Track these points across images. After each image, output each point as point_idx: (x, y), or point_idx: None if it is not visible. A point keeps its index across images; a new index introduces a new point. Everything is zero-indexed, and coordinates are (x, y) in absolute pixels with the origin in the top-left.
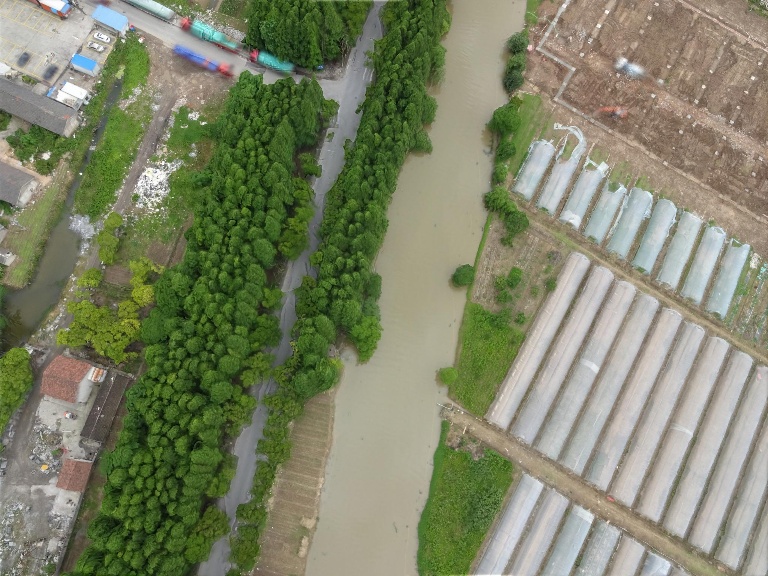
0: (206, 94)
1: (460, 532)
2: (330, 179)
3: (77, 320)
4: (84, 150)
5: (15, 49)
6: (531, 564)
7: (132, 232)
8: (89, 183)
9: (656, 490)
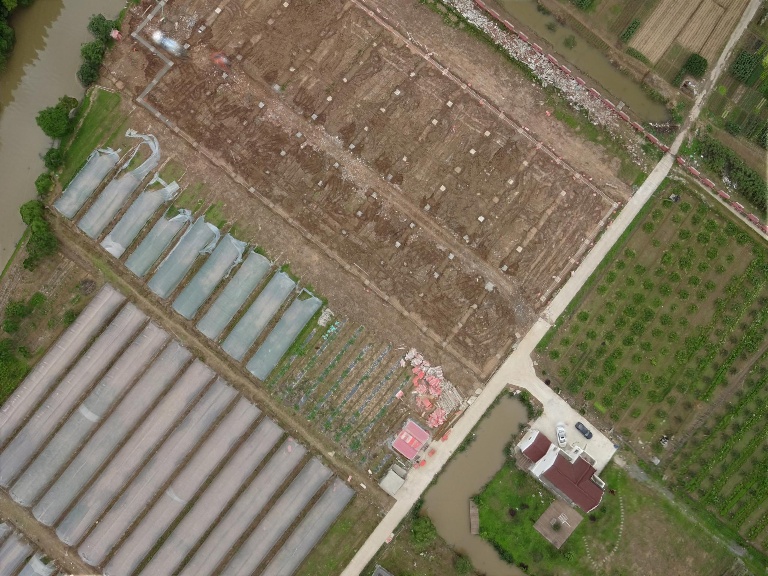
0: None
1: None
2: None
3: None
4: None
5: None
6: None
7: None
8: None
9: (133, 552)
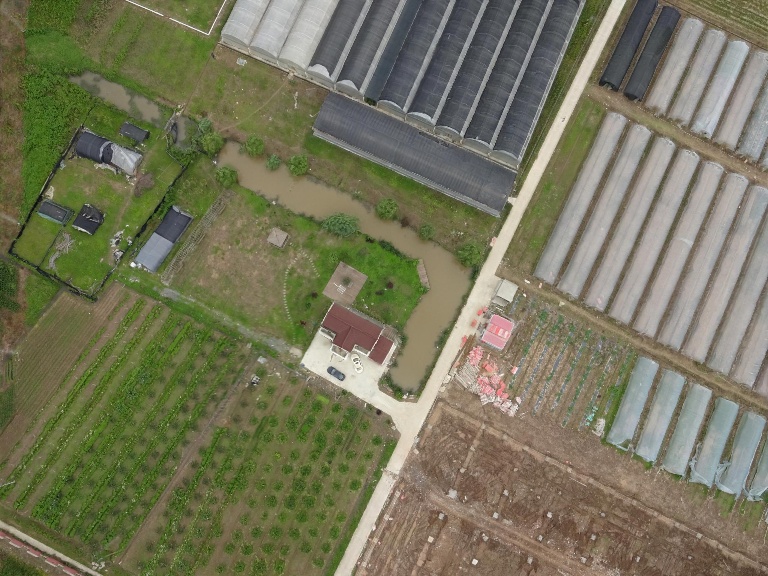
0: None
1: None
2: None
3: None
4: None
5: None
6: None
7: None
8: None
9: (703, 189)
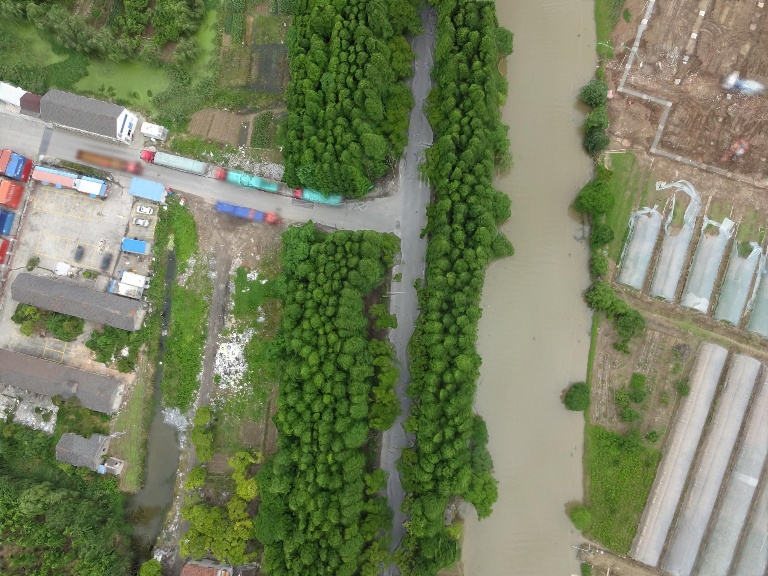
0: (259, 247)
1: None
2: (407, 316)
3: (193, 528)
4: (157, 338)
5: (69, 244)
6: None
7: (222, 416)
8: (170, 374)
9: None
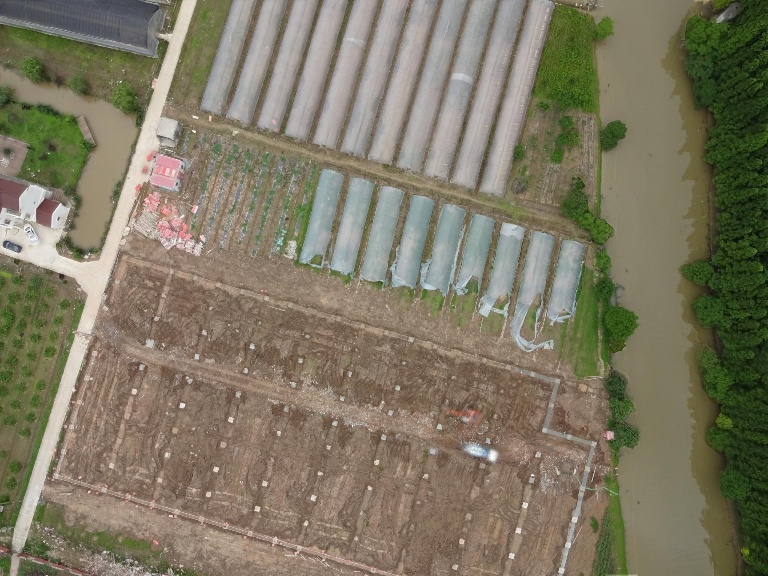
0: None
1: None
2: None
3: None
4: None
5: None
6: None
7: None
8: None
9: None
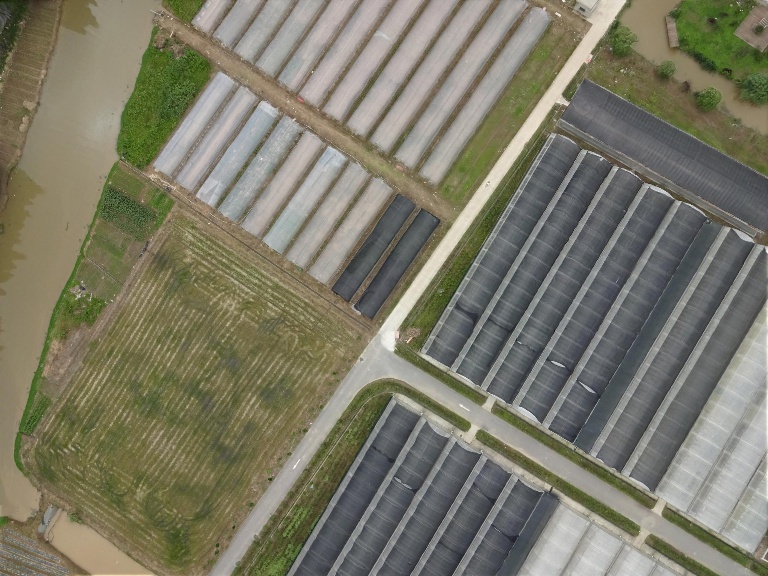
0: None
1: (154, 119)
2: None
3: None
4: None
5: None
6: (215, 150)
7: None
8: None
9: (347, 94)
